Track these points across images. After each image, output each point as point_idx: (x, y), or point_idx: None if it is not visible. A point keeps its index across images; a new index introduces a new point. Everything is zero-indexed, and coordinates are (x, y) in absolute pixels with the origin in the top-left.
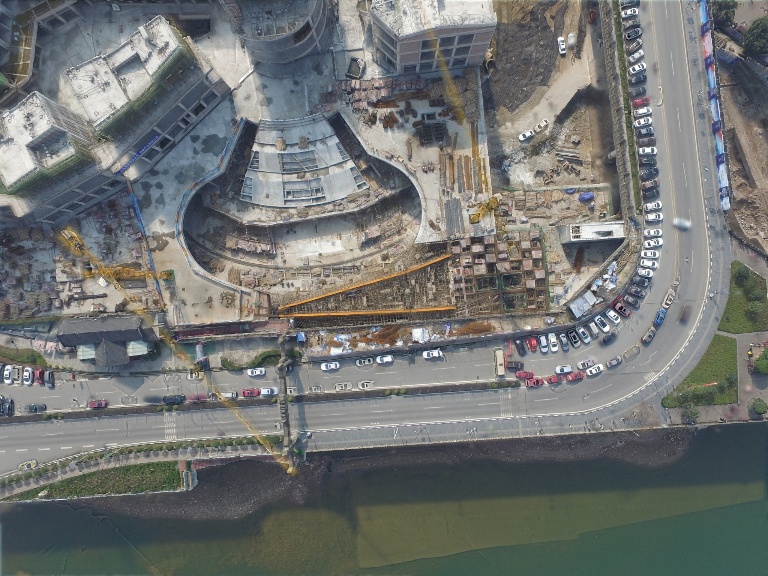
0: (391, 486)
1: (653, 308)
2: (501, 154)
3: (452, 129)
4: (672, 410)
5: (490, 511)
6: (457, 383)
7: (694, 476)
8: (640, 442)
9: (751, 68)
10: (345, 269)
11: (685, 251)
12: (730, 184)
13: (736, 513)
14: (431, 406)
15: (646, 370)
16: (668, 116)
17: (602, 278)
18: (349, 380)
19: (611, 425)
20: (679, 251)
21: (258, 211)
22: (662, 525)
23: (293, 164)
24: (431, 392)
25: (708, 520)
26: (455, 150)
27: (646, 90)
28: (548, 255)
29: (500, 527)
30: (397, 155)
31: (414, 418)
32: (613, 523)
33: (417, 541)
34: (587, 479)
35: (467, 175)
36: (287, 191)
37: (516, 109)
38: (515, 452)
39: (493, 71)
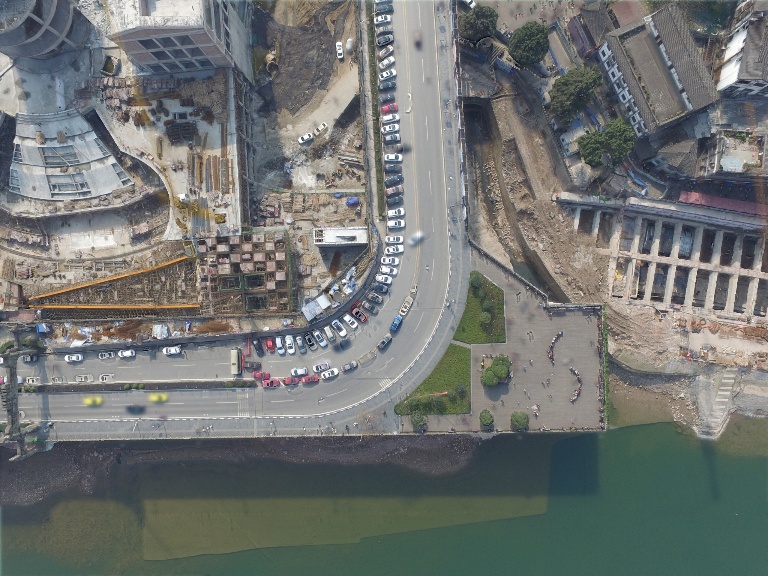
0: (178, 481)
1: (391, 315)
2: (281, 156)
3: (202, 129)
4: (405, 417)
5: (274, 511)
6: (195, 380)
7: (477, 486)
8: (423, 449)
9: (527, 79)
10: (117, 263)
11: (426, 259)
12: (467, 194)
13: (518, 526)
14: (170, 402)
15: (381, 376)
16: (416, 124)
17: (342, 283)
18: (91, 372)
19: (344, 429)
20: (419, 259)
21: (27, 203)
22: (445, 534)
23: (55, 158)
24: (169, 388)
25: (490, 531)
26: (204, 150)
27: (395, 97)
28: (304, 258)
29: (283, 527)
30: (147, 153)
31: (153, 413)
32: (395, 529)
33: (201, 537)
34: (371, 484)
35: (215, 175)
36: (53, 184)
37: (297, 112)
38: (298, 453)
39: (276, 73)
